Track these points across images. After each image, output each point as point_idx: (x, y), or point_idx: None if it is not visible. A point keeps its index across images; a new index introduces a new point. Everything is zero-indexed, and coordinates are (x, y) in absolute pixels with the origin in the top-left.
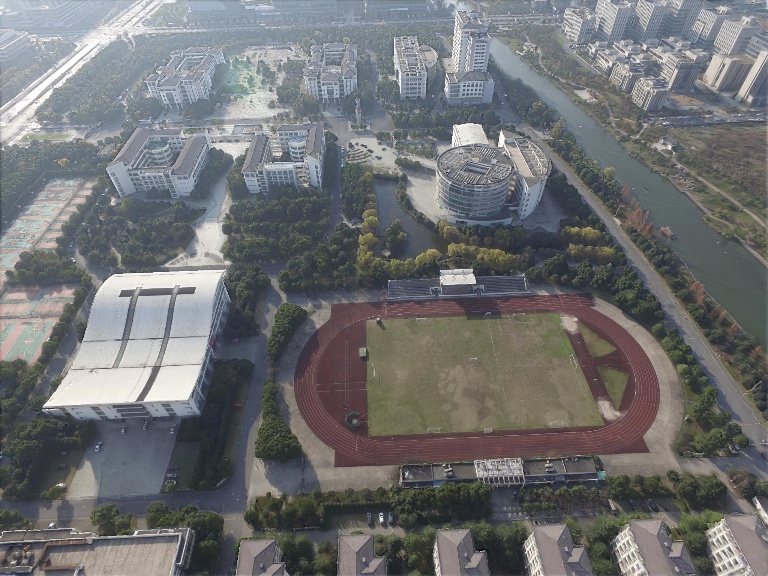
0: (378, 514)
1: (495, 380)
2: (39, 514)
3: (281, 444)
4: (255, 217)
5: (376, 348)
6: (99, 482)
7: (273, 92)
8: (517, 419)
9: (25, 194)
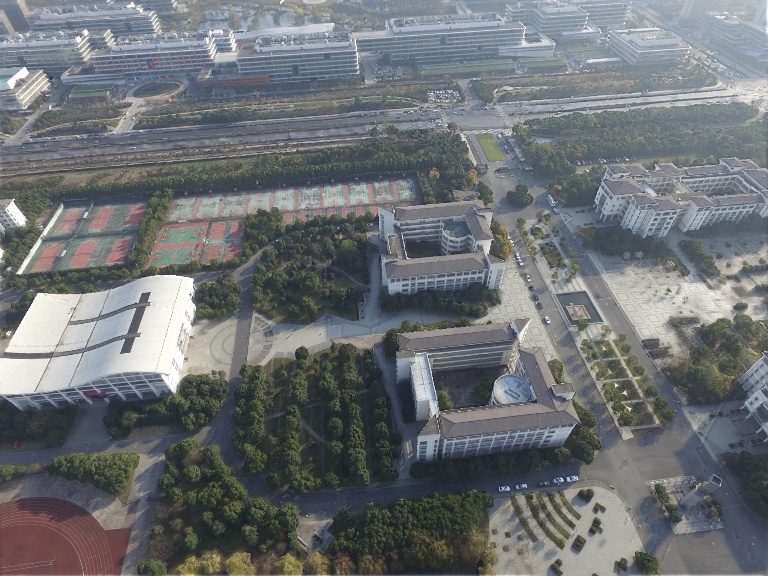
0: None
1: None
2: None
3: None
4: None
5: None
6: None
7: (735, 312)
8: None
9: (374, 174)
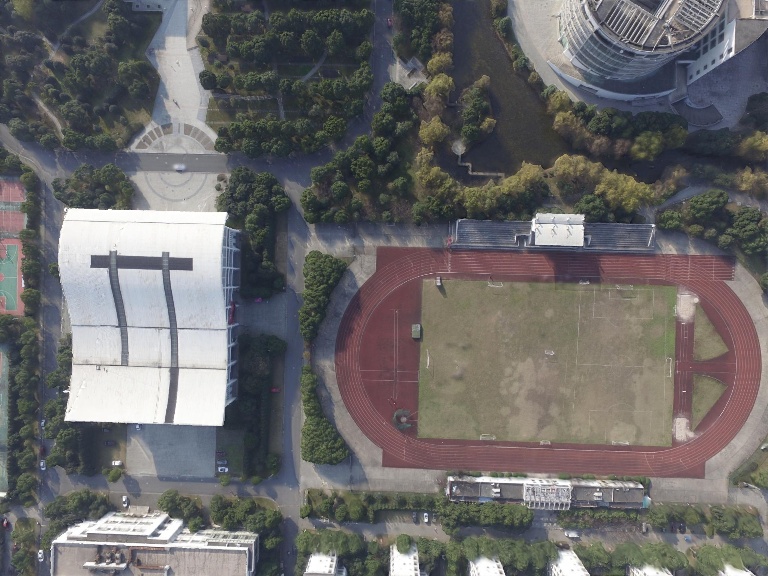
0: (423, 514)
1: (568, 382)
2: (108, 486)
3: (328, 457)
4: (249, 55)
5: (433, 325)
6: (153, 461)
7: None
8: (579, 432)
9: None
